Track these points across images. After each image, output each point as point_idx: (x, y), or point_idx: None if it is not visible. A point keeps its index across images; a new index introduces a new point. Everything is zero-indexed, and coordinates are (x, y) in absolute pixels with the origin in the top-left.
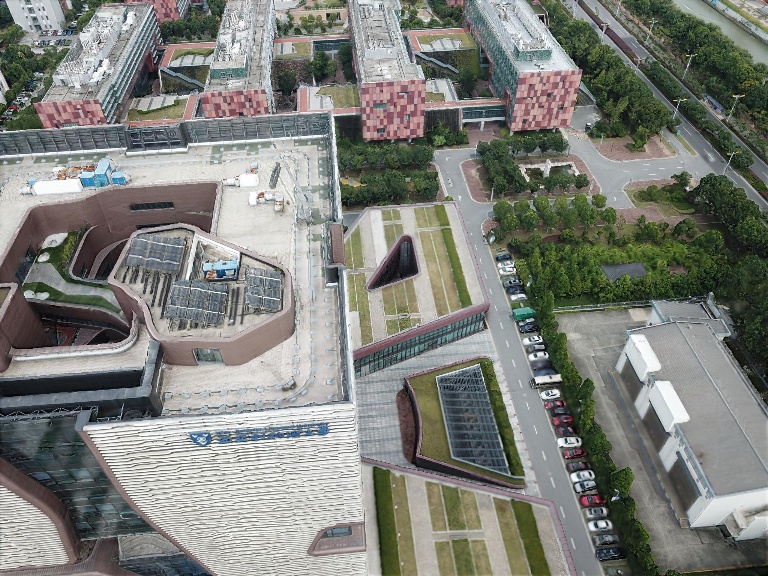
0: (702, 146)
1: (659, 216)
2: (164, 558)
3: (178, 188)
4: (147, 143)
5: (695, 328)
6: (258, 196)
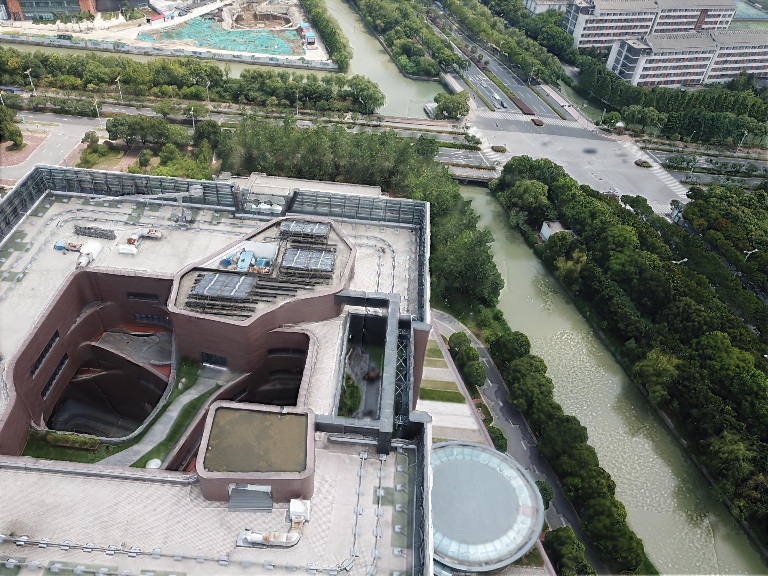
0: (52, 118)
1: (113, 169)
2: None
3: (57, 307)
4: None
5: (259, 181)
6: (130, 243)
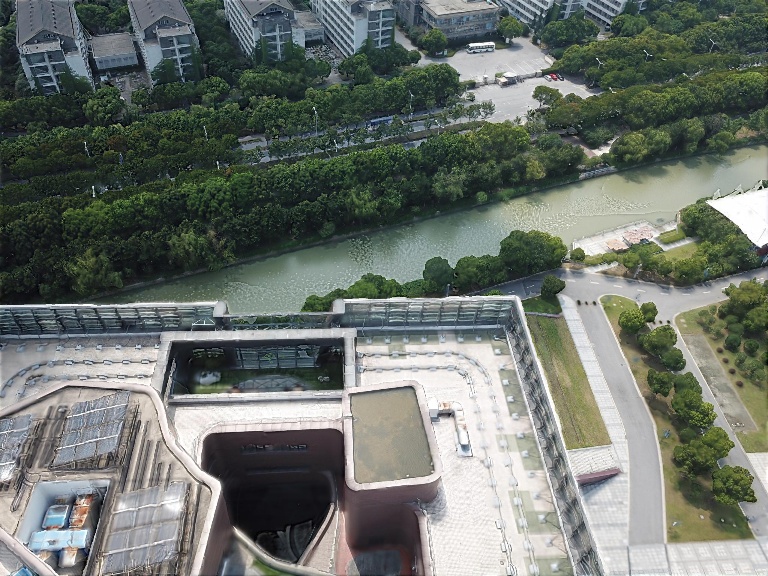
0: None
1: None
2: None
3: None
4: None
5: None
6: None
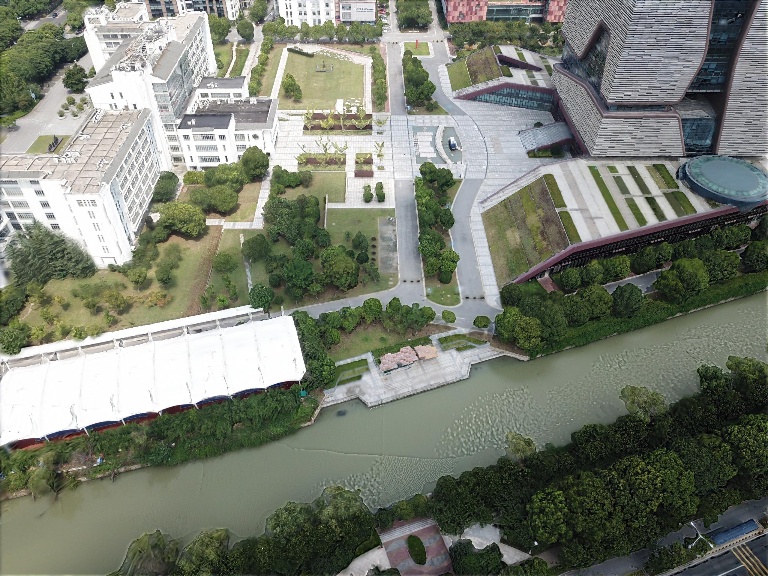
0: None
1: None
2: (699, 118)
3: None
4: (497, 17)
5: None
6: None
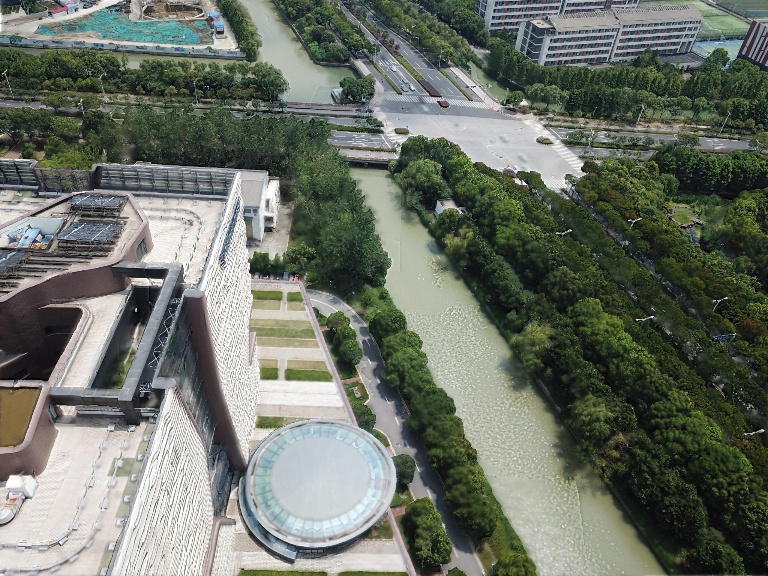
0: None
1: None
2: (216, 478)
3: None
4: None
5: None
6: None
